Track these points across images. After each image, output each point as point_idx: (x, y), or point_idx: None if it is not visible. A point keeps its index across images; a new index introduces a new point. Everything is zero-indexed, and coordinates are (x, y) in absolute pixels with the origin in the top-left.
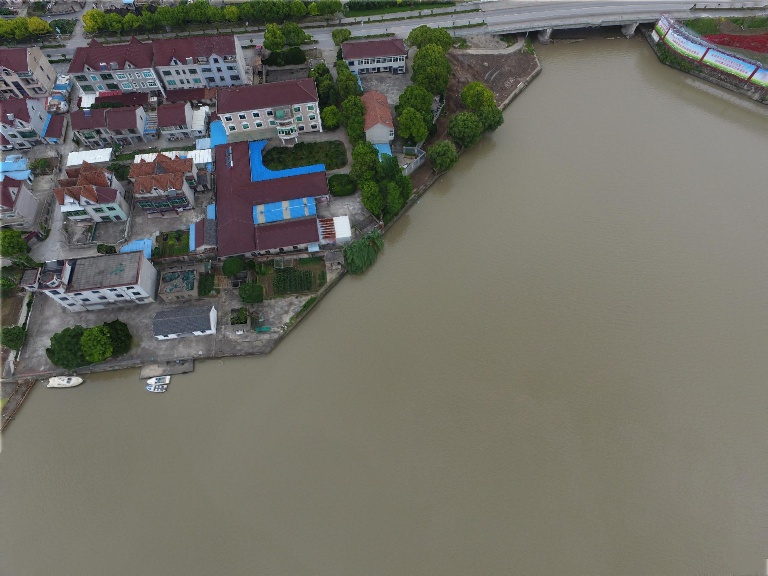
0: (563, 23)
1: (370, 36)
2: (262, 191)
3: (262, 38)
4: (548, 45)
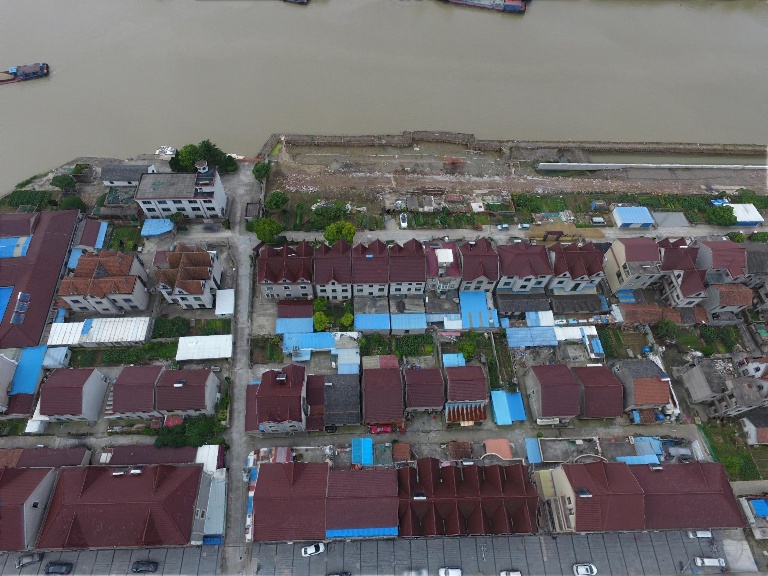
0: None
1: None
2: (3, 264)
3: None
4: None
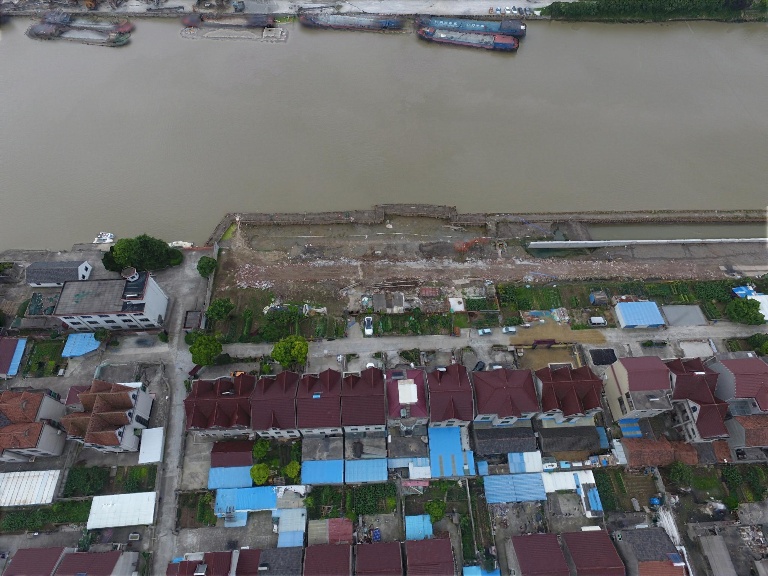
0: None
1: None
2: None
3: None
4: None
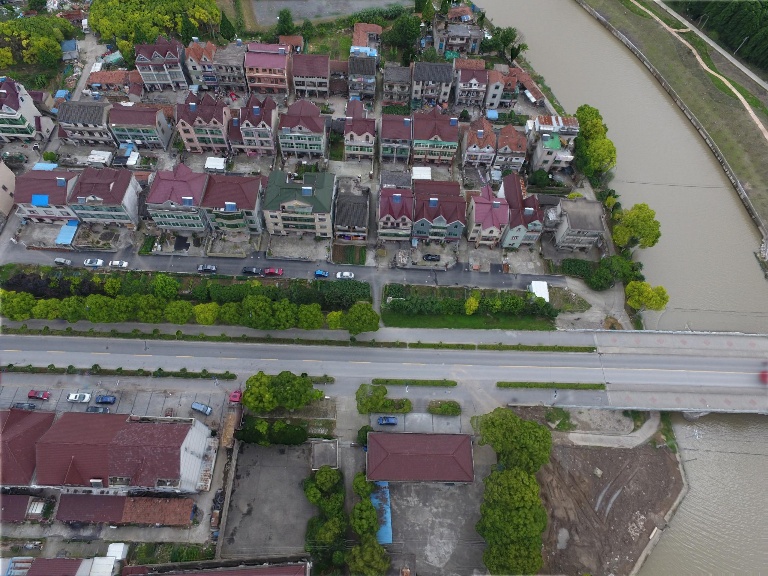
0: (731, 410)
1: (417, 383)
2: None
3: (248, 356)
4: (695, 421)
